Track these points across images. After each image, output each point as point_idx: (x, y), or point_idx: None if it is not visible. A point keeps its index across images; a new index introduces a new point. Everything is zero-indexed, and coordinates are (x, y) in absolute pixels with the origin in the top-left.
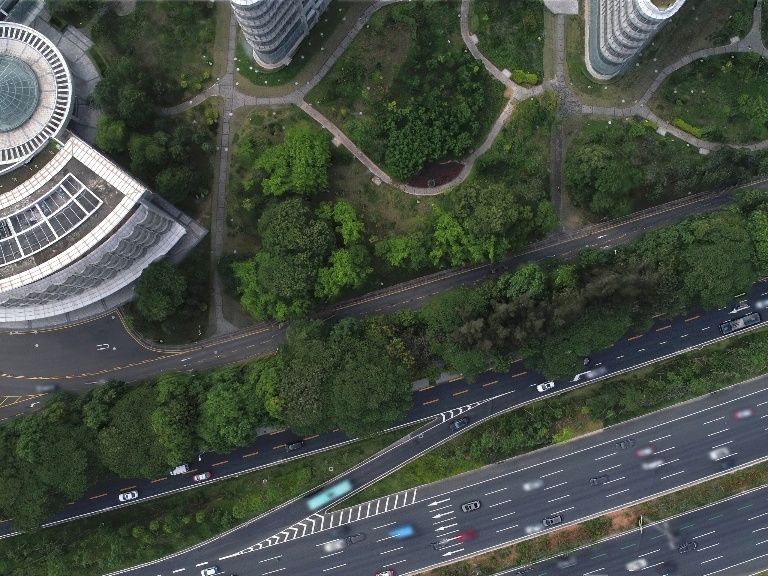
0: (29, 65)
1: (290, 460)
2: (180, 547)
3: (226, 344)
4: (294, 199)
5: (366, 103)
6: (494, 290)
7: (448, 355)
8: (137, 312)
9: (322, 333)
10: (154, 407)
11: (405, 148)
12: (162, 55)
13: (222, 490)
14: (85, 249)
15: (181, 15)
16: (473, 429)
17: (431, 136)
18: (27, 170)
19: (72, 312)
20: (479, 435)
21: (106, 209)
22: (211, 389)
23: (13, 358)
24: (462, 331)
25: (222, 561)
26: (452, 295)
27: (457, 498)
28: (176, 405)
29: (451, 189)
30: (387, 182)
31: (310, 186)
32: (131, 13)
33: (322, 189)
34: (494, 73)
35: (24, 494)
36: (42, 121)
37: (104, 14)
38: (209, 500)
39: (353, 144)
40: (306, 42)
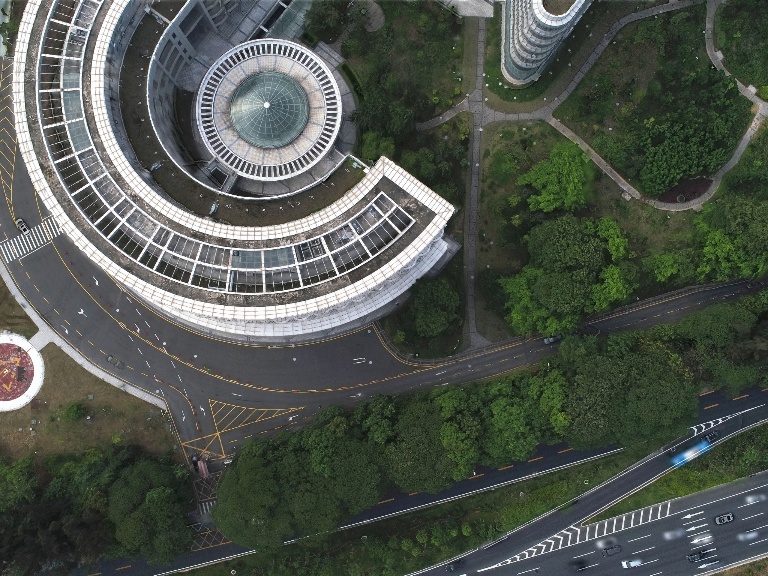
0: (298, 82)
1: (545, 473)
2: (439, 559)
3: (480, 358)
4: (563, 215)
5: (616, 119)
6: (759, 306)
7: (719, 370)
8: (410, 327)
9: (599, 349)
10: (440, 422)
11: (664, 164)
12: (413, 71)
13: (479, 503)
14: (399, 267)
15: (432, 31)
16: (725, 442)
17: (688, 152)
18: (323, 188)
19: (338, 327)
20: (732, 448)
21: (418, 228)
22: (493, 404)
23: (271, 372)
24: (735, 347)
25: (481, 573)
26: (722, 311)
27: (710, 511)
28: (462, 420)
29: (700, 204)
30: (637, 197)
31: (574, 202)
32: (382, 29)
33: (582, 205)
34: (740, 89)
35: (318, 508)
36: (312, 137)
37: (354, 30)
38: (467, 513)
39: (602, 159)
40: (555, 58)
